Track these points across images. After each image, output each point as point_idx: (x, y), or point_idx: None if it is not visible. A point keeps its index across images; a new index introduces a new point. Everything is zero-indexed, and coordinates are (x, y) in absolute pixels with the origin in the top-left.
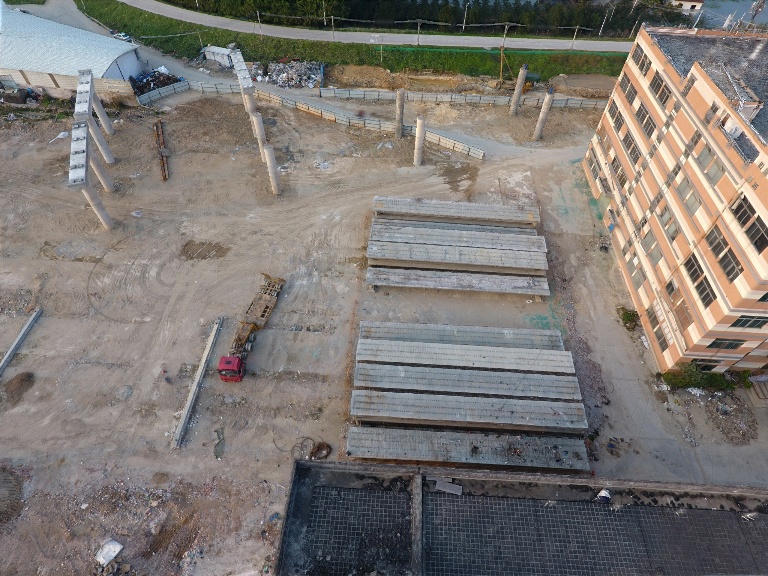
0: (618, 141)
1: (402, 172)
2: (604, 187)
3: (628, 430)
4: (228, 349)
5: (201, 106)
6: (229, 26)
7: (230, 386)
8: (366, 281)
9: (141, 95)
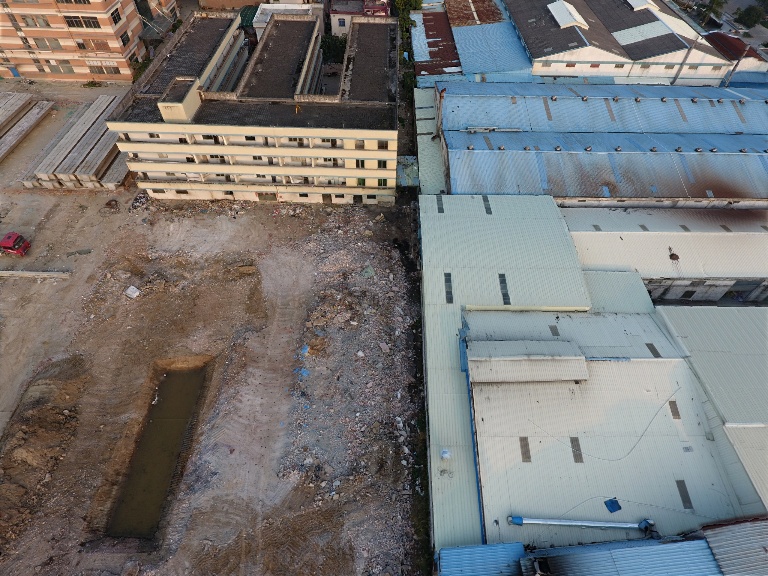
0: None
1: None
2: None
3: None
4: None
5: None
6: None
7: (31, 254)
8: None
9: None
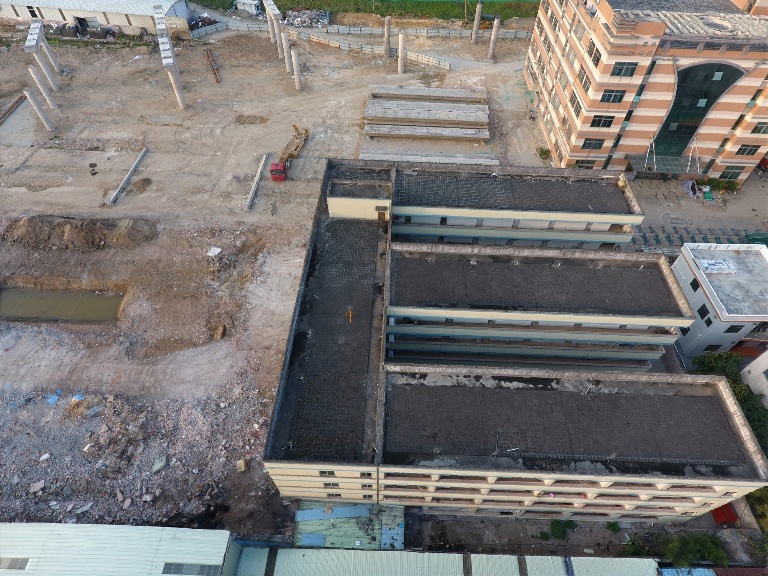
0: (541, 43)
1: (389, 77)
2: (533, 77)
3: None
4: None
5: (237, 39)
6: None
7: (277, 184)
8: (364, 131)
9: (193, 31)
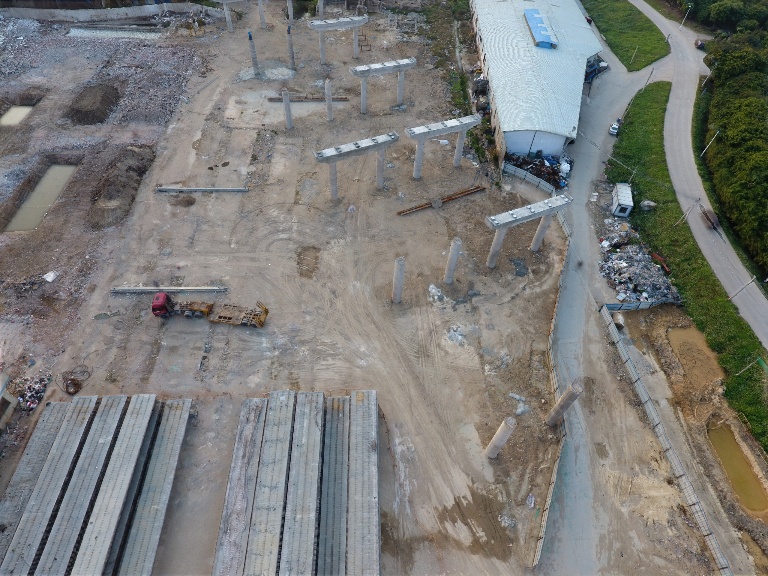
0: None
1: (465, 431)
2: None
3: None
4: None
5: None
6: (684, 190)
7: None
8: None
9: None
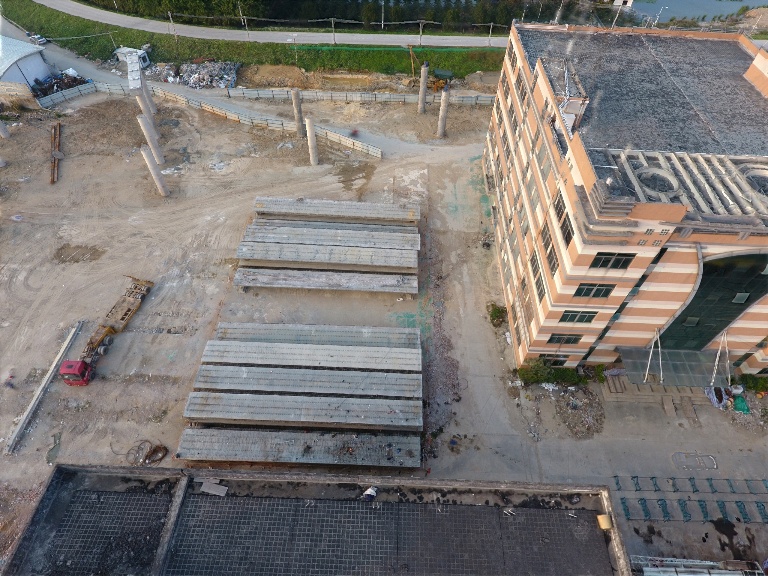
0: None
1: (297, 172)
2: (489, 184)
3: (473, 426)
4: None
5: (105, 108)
6: (146, 27)
7: (76, 390)
8: (233, 282)
9: (42, 98)
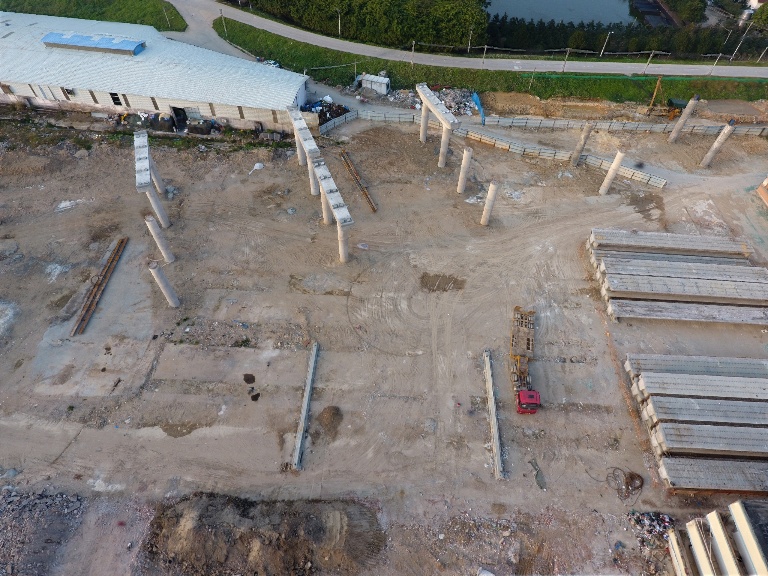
0: None
1: (592, 201)
2: None
3: None
4: (507, 381)
5: (375, 135)
6: (375, 54)
7: (524, 418)
8: (614, 313)
9: (321, 126)
